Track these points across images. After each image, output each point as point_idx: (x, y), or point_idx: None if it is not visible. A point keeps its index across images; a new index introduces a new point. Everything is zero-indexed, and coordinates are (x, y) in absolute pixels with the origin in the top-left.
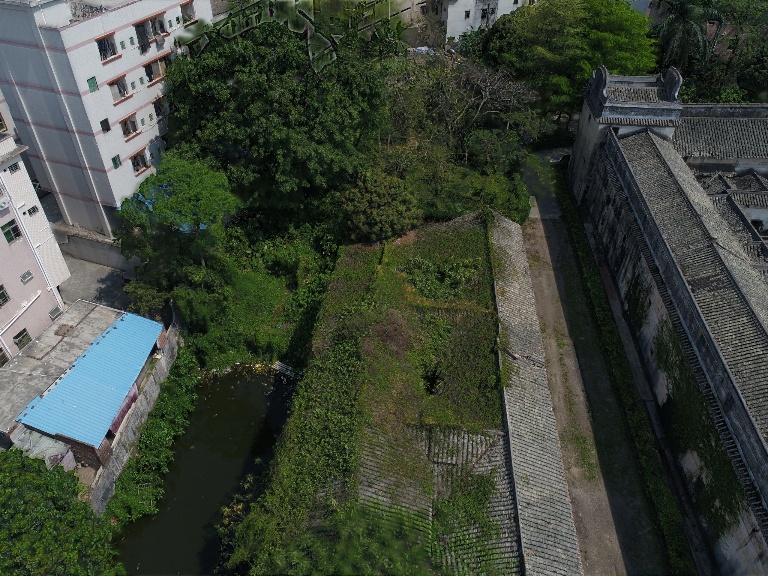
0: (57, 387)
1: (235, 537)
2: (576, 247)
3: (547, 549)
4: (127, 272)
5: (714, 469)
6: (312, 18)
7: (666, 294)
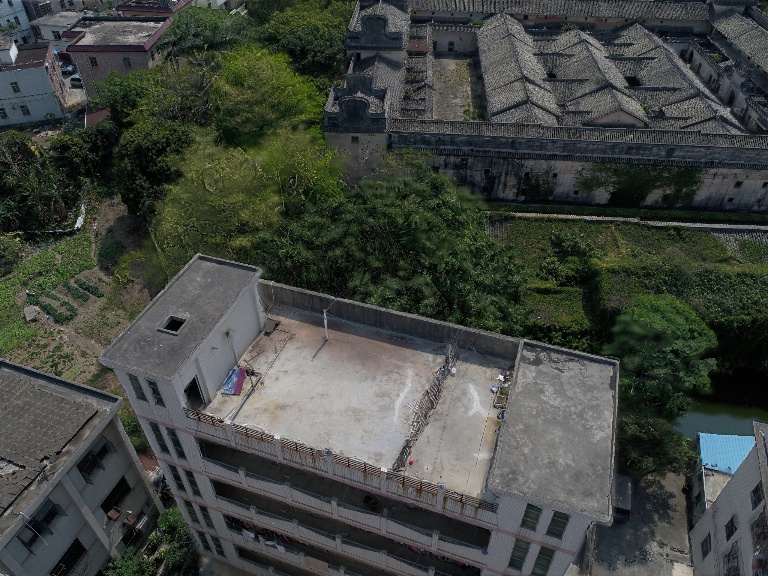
0: None
1: None
2: None
3: None
4: (622, 505)
5: (676, 181)
6: None
7: (577, 157)
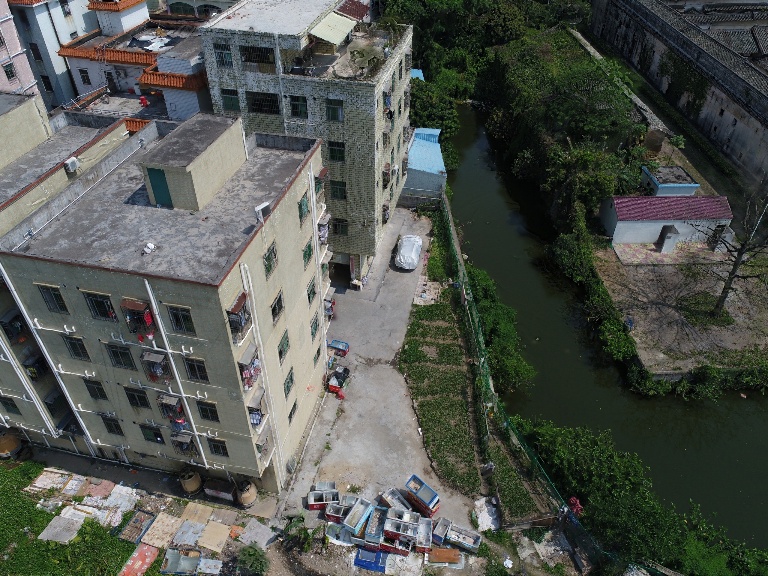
0: None
1: (512, 109)
2: (605, 51)
3: None
4: None
5: (694, 89)
6: None
7: (663, 39)
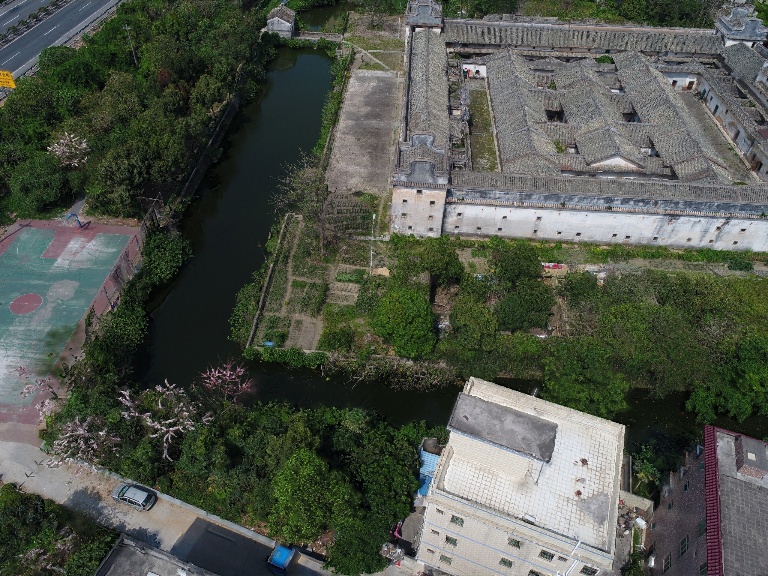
0: None
1: None
2: None
3: None
4: None
5: None
6: None
7: None
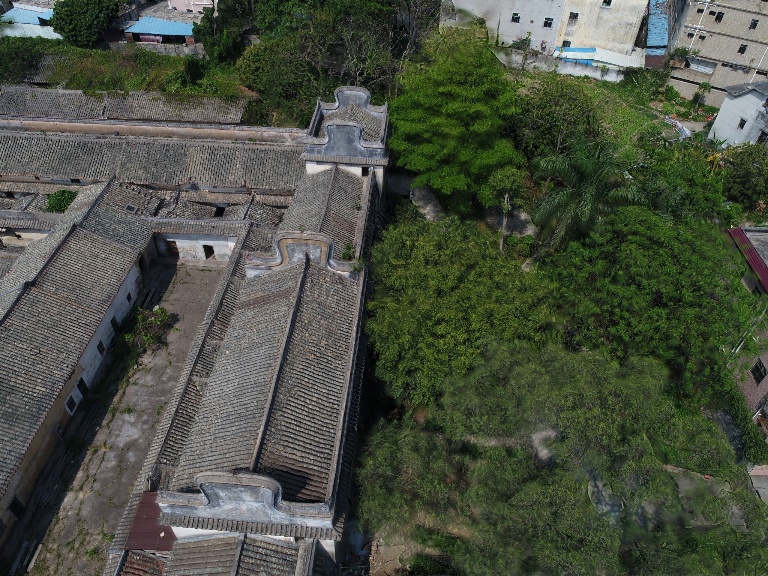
0: (159, 19)
1: None
2: None
3: (4, 99)
4: None
5: None
6: (633, 35)
7: None
